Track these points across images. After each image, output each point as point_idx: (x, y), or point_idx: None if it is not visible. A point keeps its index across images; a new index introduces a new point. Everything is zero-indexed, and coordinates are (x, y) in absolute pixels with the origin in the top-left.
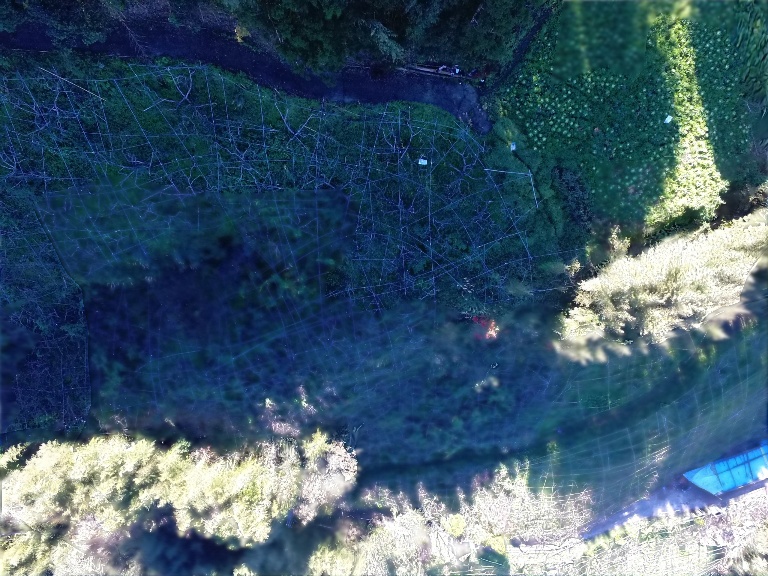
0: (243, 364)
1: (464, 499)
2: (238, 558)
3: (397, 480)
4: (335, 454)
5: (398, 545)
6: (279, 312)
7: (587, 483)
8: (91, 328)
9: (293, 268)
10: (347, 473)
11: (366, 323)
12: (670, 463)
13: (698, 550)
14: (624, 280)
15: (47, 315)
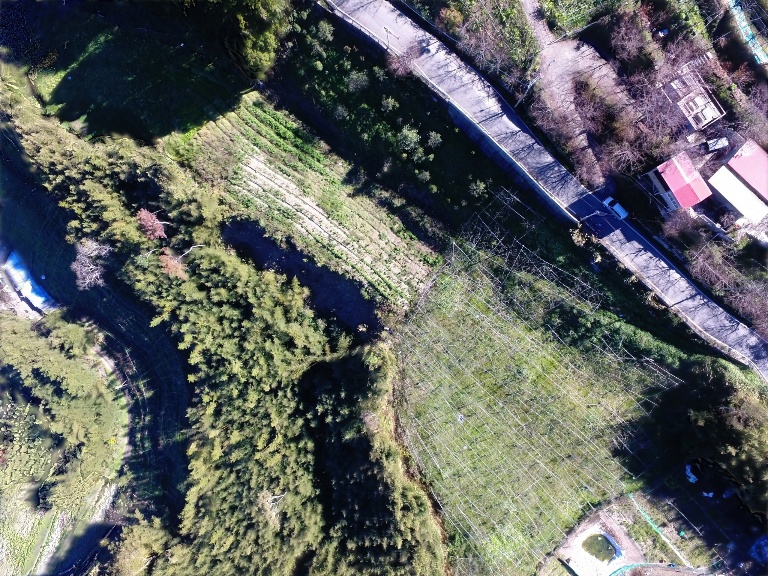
0: None
1: None
2: None
3: None
4: None
5: None
6: None
7: None
8: None
9: None
10: None
11: None
12: None
13: None
14: None
15: None
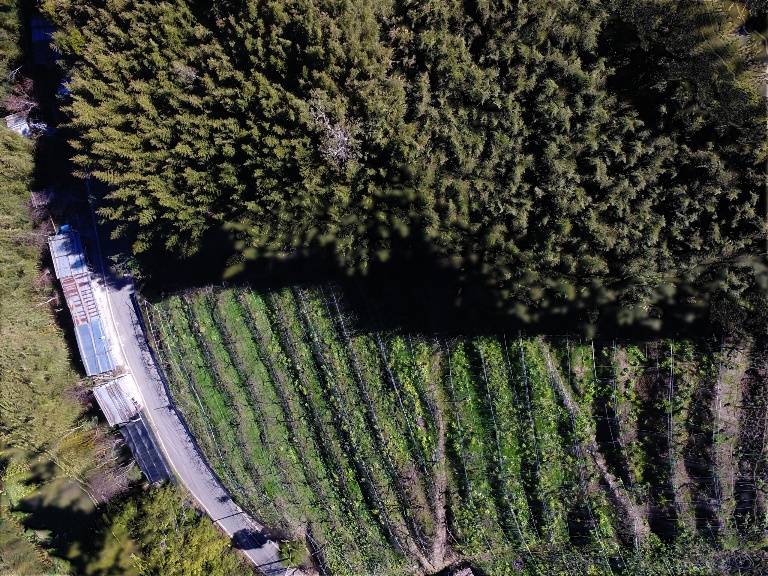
0: None
1: None
2: None
3: None
4: None
5: None
6: None
7: None
8: None
9: None
10: None
11: None
12: None
13: None
14: None
15: None
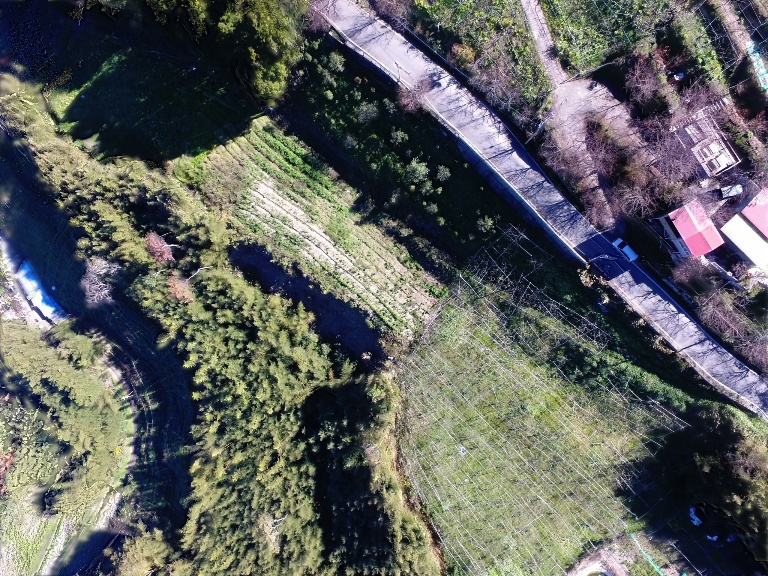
0: None
1: None
2: None
3: None
4: None
5: None
6: (7, 8)
7: None
8: None
9: (19, 7)
10: None
11: (3, 36)
12: (12, 225)
13: None
14: (8, 95)
15: None
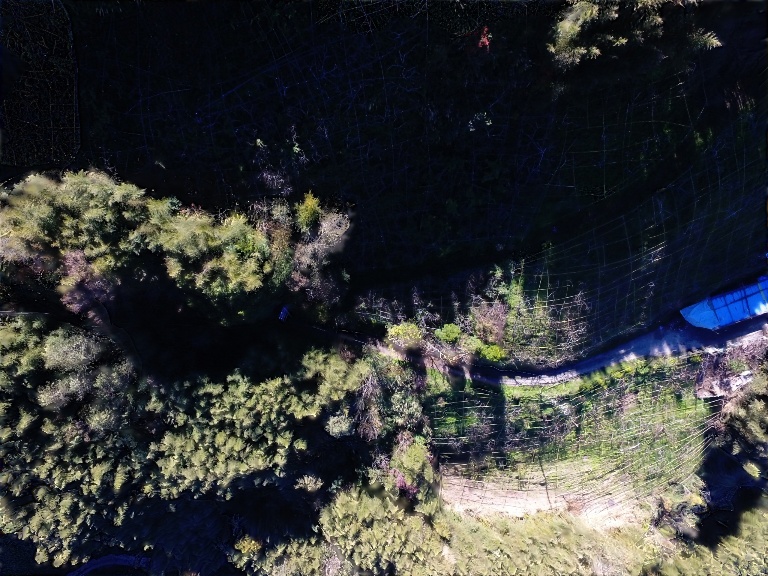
0: (234, 101)
1: (459, 309)
2: (231, 354)
3: (391, 288)
4: (327, 218)
5: (393, 369)
6: (270, 46)
7: (582, 282)
8: (80, 66)
9: None
10: (339, 229)
11: (358, 47)
12: (666, 275)
13: (695, 404)
14: None
15: (35, 43)
